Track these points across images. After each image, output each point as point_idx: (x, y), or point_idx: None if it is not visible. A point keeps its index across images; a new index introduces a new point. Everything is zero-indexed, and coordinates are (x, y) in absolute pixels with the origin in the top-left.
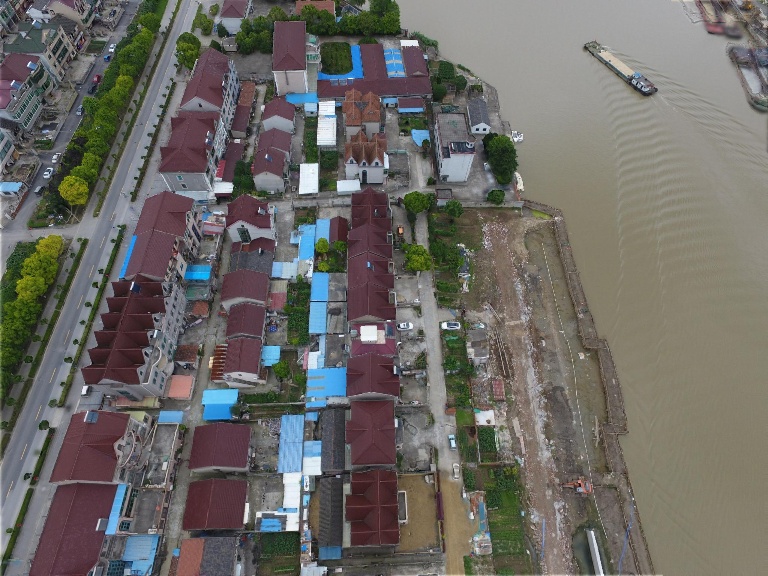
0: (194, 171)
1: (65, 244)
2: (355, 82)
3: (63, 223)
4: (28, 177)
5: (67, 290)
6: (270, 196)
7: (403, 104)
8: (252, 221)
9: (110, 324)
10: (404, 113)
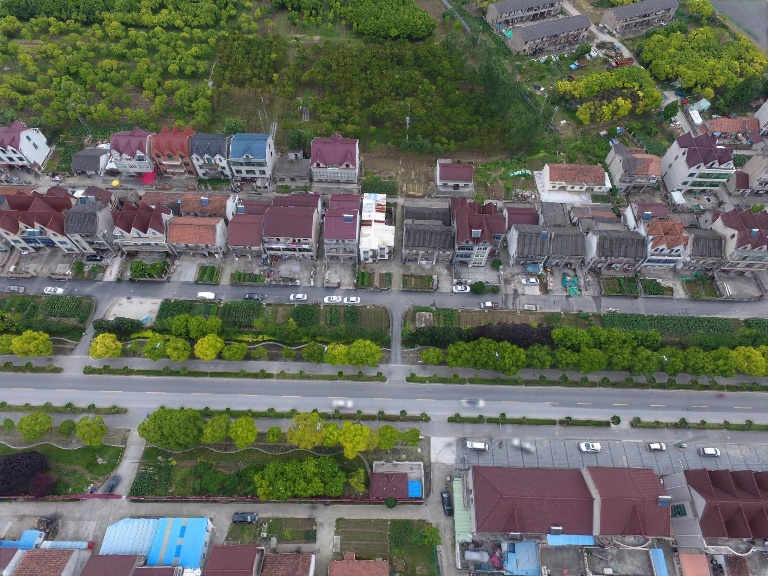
0: None
1: None
2: None
3: None
4: None
5: (751, 390)
6: None
7: None
8: None
9: (760, 480)
10: None
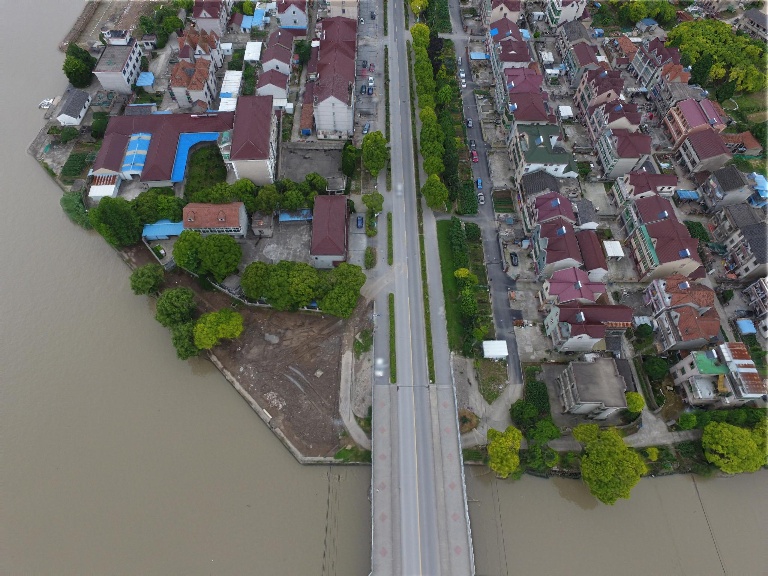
0: None
1: None
2: None
3: None
4: None
5: None
6: None
7: None
8: None
9: None
10: None
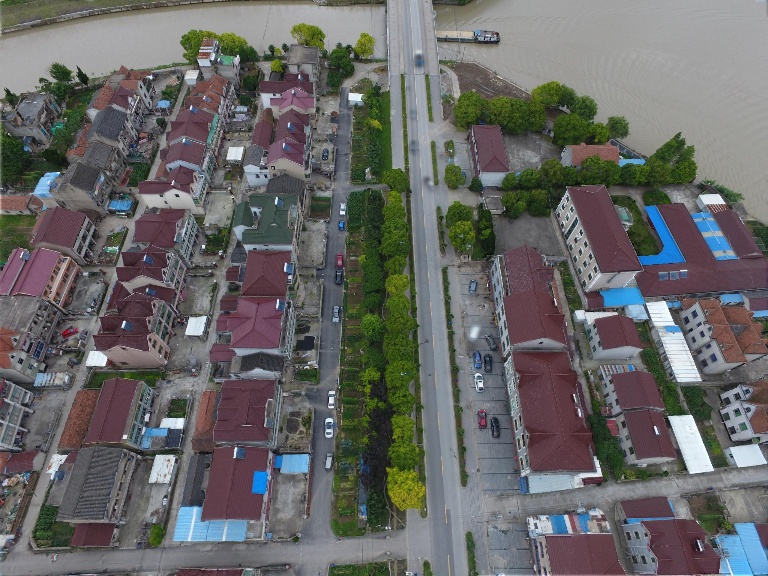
0: (580, 469)
1: (400, 572)
2: (688, 274)
3: (383, 529)
4: (310, 441)
5: None
6: (650, 477)
7: (755, 305)
8: (696, 567)
9: None
10: (756, 317)
